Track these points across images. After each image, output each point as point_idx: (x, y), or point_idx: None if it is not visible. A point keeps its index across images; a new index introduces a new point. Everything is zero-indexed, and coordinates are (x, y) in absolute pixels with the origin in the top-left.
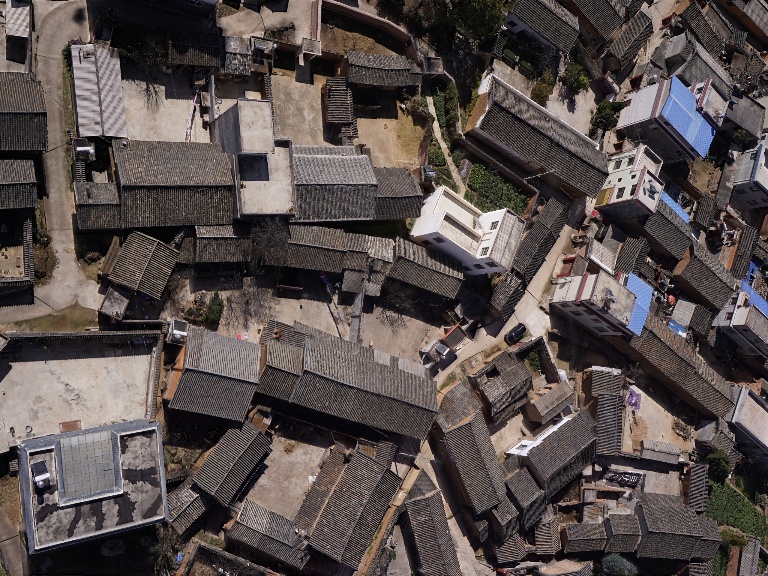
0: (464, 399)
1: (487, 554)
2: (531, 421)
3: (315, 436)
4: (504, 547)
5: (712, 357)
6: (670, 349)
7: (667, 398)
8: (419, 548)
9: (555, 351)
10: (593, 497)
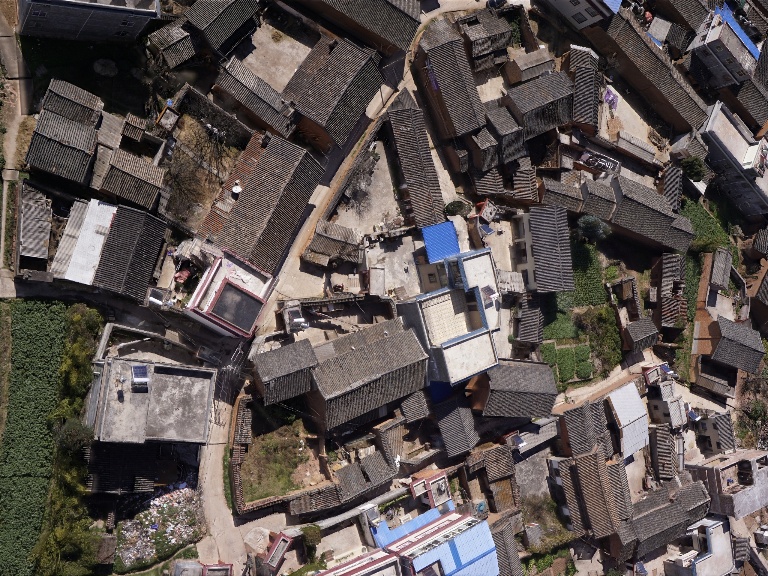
0: (446, 33)
1: (467, 193)
2: (511, 84)
3: (302, 34)
4: (483, 180)
5: None
6: (646, 45)
7: (643, 107)
8: (401, 158)
9: (535, 30)
10: (570, 165)
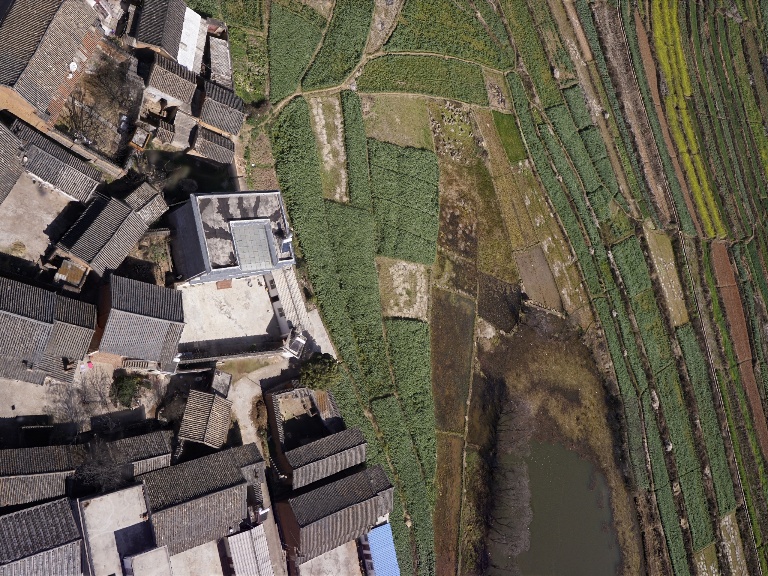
0: None
1: None
2: None
3: None
4: None
5: None
6: None
7: None
8: None
9: None
10: None
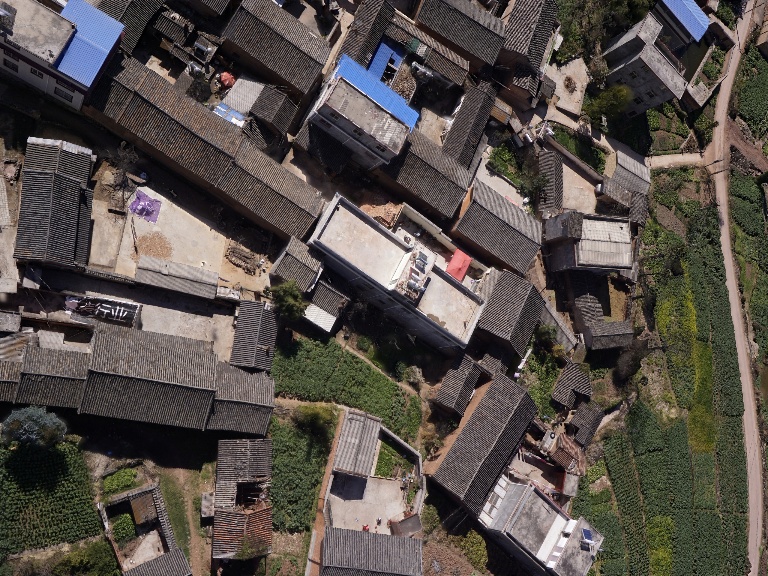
0: None
1: None
2: None
3: None
4: None
5: (316, 169)
6: (180, 125)
7: (216, 212)
8: None
9: None
10: (14, 325)
